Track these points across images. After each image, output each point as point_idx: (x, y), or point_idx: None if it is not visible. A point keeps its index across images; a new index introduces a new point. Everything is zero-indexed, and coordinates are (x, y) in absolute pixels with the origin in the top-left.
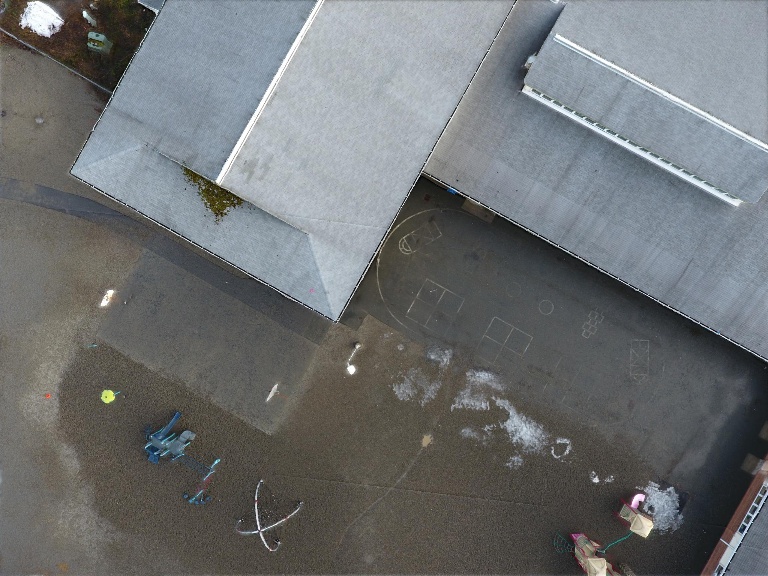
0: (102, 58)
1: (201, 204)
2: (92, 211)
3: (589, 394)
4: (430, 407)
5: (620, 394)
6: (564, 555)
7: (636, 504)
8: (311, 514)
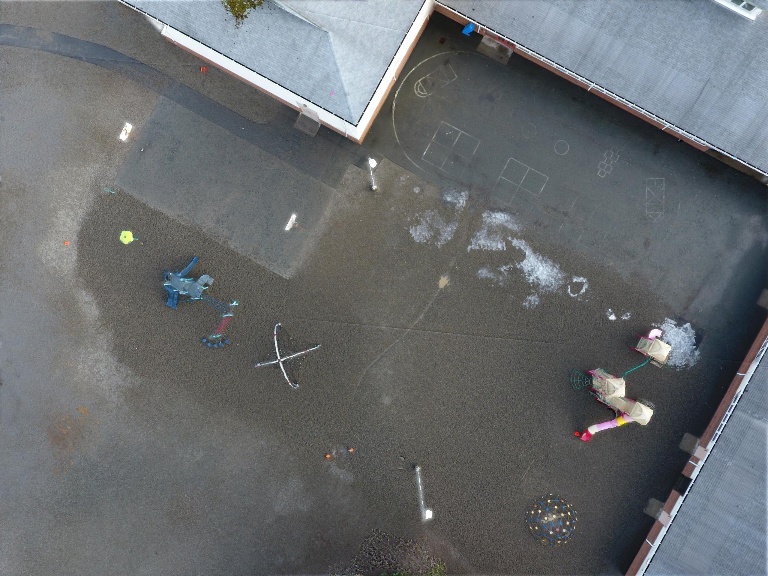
0: None
1: (221, 7)
2: (109, 59)
3: (605, 233)
4: (447, 248)
5: (636, 232)
6: (581, 392)
7: (653, 337)
8: (329, 356)
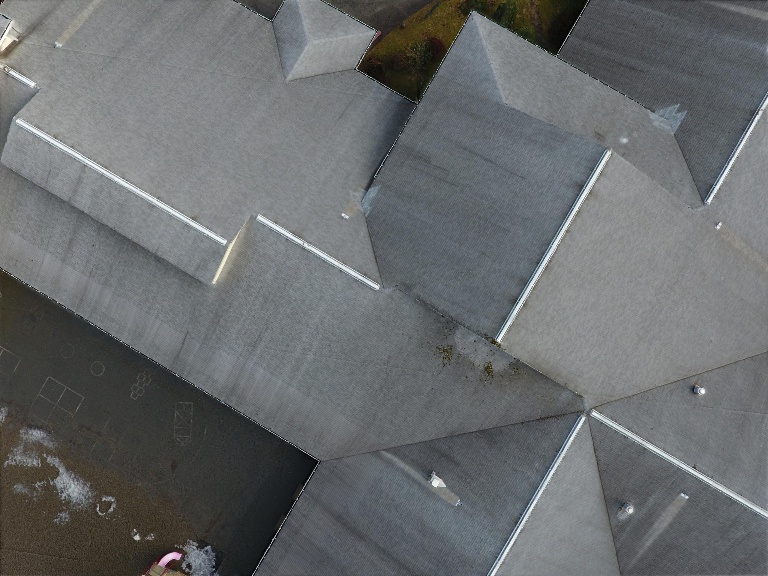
0: None
1: None
2: None
3: (135, 454)
4: None
5: (164, 454)
6: None
7: (164, 563)
8: None
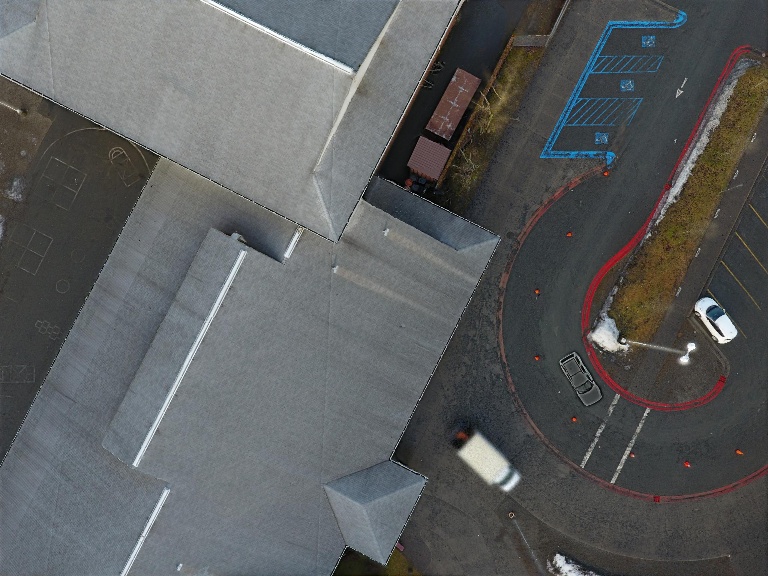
0: None
1: None
2: None
3: None
4: None
5: None
6: None
7: None
8: None
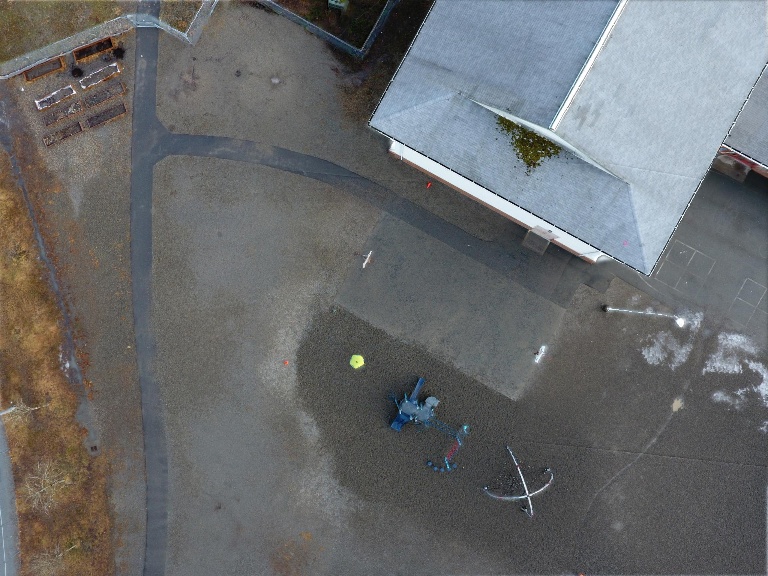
0: (341, 16)
1: (512, 154)
2: (330, 173)
3: None
4: (681, 371)
5: None
6: None
7: None
8: (558, 481)
